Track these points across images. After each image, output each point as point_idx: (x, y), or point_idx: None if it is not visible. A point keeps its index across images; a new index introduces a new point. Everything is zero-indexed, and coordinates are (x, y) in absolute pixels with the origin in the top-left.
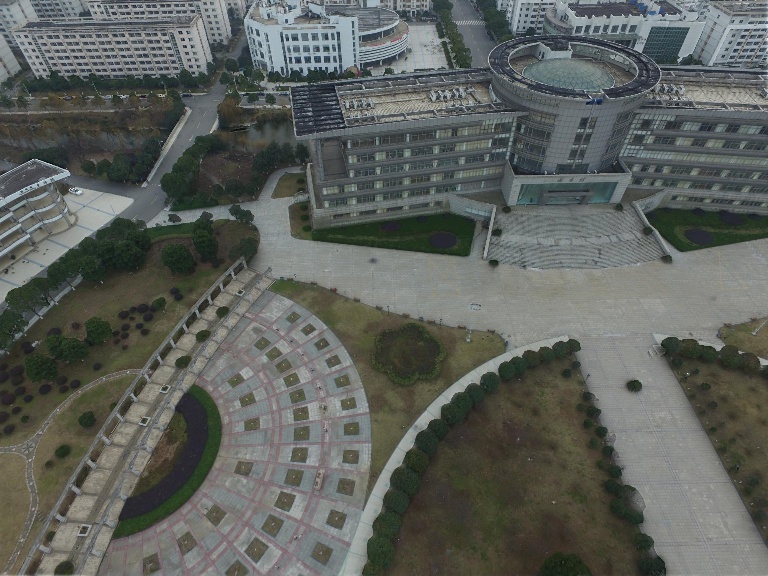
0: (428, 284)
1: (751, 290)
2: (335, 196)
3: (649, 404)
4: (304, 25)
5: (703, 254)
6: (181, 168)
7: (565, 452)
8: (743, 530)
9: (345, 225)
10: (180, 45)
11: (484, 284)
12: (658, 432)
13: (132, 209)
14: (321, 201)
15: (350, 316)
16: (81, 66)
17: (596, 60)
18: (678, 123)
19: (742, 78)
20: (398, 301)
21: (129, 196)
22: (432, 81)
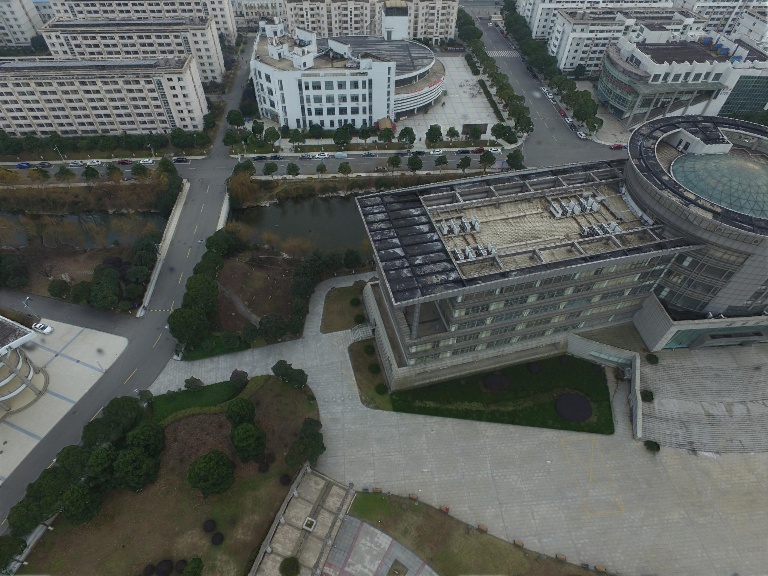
0: (574, 491)
1: None
2: (427, 354)
3: None
4: (329, 71)
5: None
6: (196, 300)
7: None
8: None
9: (433, 381)
10: (169, 94)
11: (651, 487)
12: None
13: (127, 358)
14: (399, 350)
15: (481, 565)
16: (38, 120)
17: (750, 151)
18: None
19: None
20: (542, 528)
21: (120, 334)
22: (544, 182)
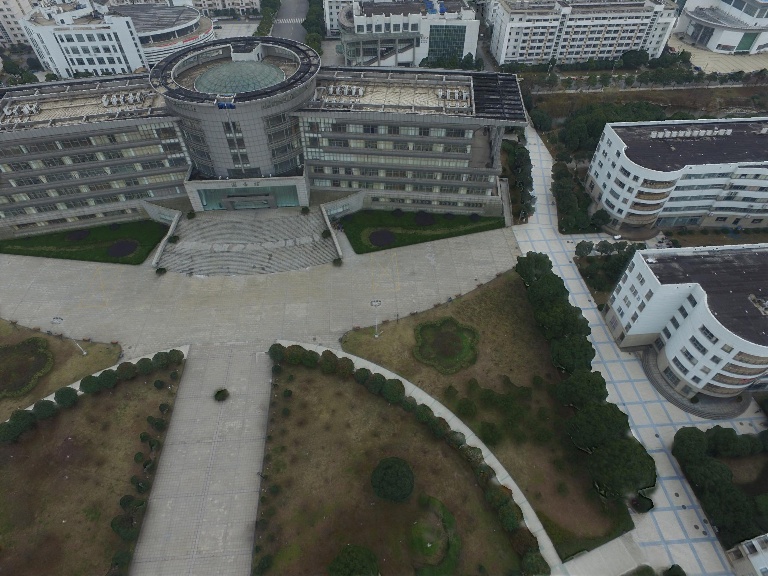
0: (81, 295)
1: (402, 291)
2: (4, 206)
3: (227, 413)
4: (76, 25)
5: (378, 256)
6: None
7: (108, 468)
8: (239, 541)
9: (32, 235)
10: None
11: (138, 293)
12: (217, 442)
13: None
14: None
15: None
16: None
17: (290, 62)
18: (341, 125)
19: (430, 78)
20: (38, 314)
21: None
22: (119, 85)
